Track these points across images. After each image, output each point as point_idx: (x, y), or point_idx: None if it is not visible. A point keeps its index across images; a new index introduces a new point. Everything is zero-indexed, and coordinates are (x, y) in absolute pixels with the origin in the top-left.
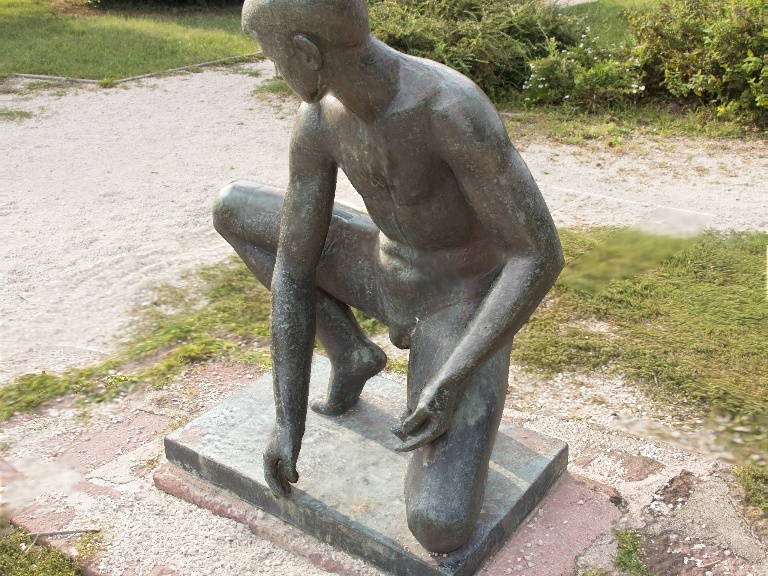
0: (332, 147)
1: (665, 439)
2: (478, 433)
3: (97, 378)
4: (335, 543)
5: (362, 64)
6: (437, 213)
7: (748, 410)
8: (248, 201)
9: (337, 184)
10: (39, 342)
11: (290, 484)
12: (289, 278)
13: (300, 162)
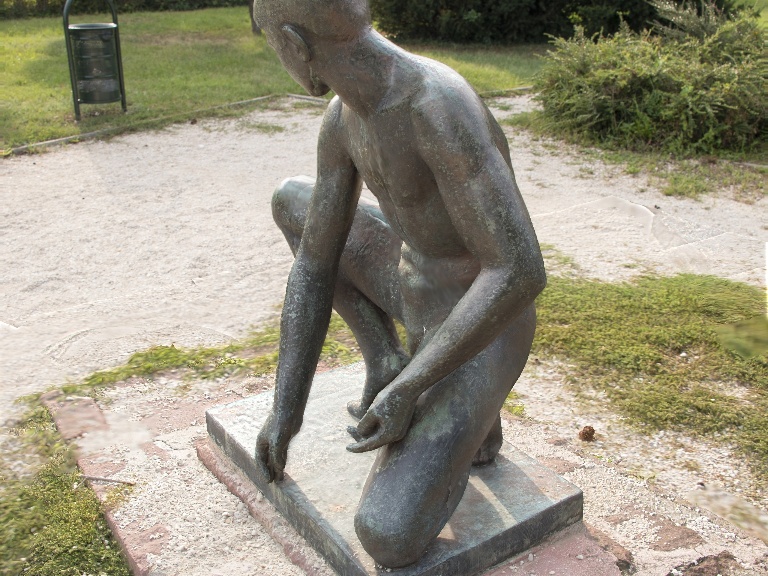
0: (346, 143)
1: (748, 521)
2: (437, 449)
3: (213, 358)
4: (307, 537)
5: (352, 58)
6: (431, 217)
7: None
8: (298, 195)
9: (532, 217)
10: (188, 321)
11: (287, 473)
12: (304, 269)
13: (322, 157)
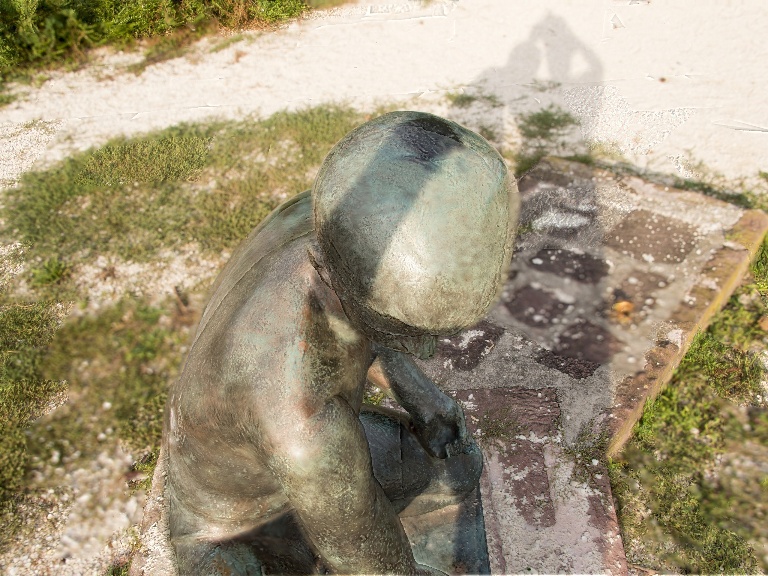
0: None
1: (99, 503)
2: None
3: None
4: None
5: None
6: None
7: (21, 460)
8: None
9: None
10: None
11: None
12: None
13: None
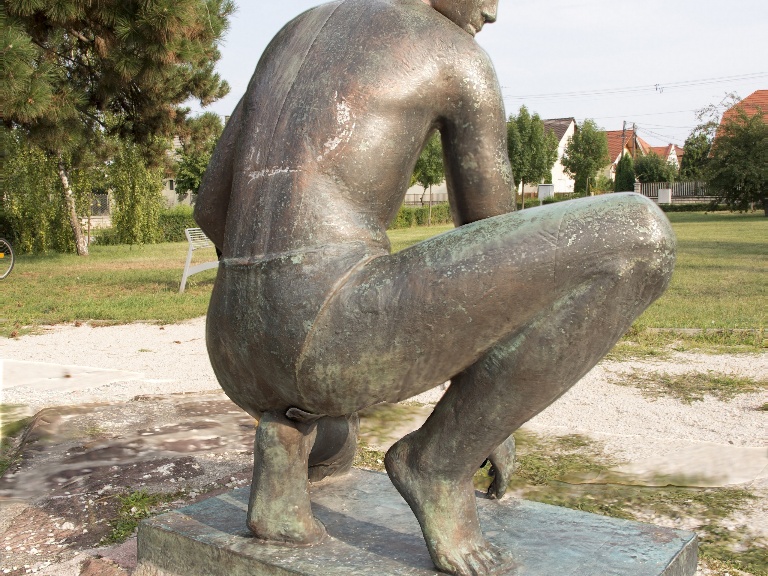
0: None
1: None
2: None
3: None
4: None
5: None
6: None
7: None
8: None
9: None
10: None
11: (492, 499)
12: None
13: None
